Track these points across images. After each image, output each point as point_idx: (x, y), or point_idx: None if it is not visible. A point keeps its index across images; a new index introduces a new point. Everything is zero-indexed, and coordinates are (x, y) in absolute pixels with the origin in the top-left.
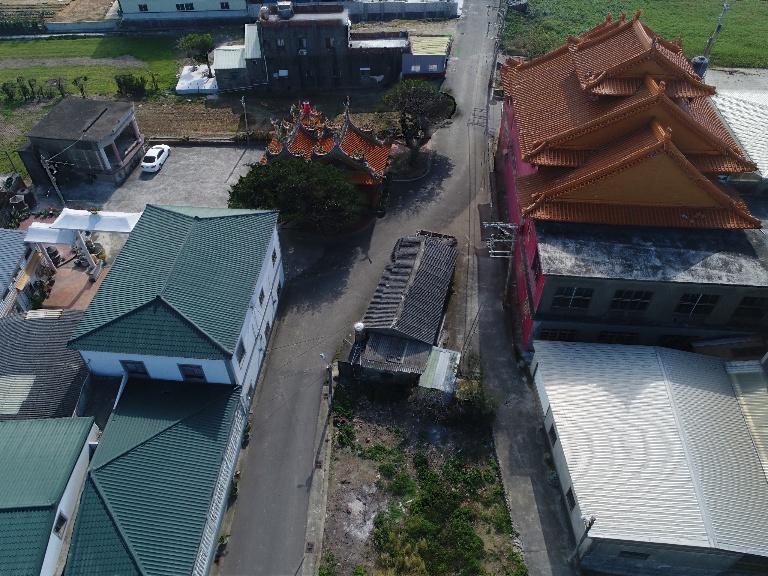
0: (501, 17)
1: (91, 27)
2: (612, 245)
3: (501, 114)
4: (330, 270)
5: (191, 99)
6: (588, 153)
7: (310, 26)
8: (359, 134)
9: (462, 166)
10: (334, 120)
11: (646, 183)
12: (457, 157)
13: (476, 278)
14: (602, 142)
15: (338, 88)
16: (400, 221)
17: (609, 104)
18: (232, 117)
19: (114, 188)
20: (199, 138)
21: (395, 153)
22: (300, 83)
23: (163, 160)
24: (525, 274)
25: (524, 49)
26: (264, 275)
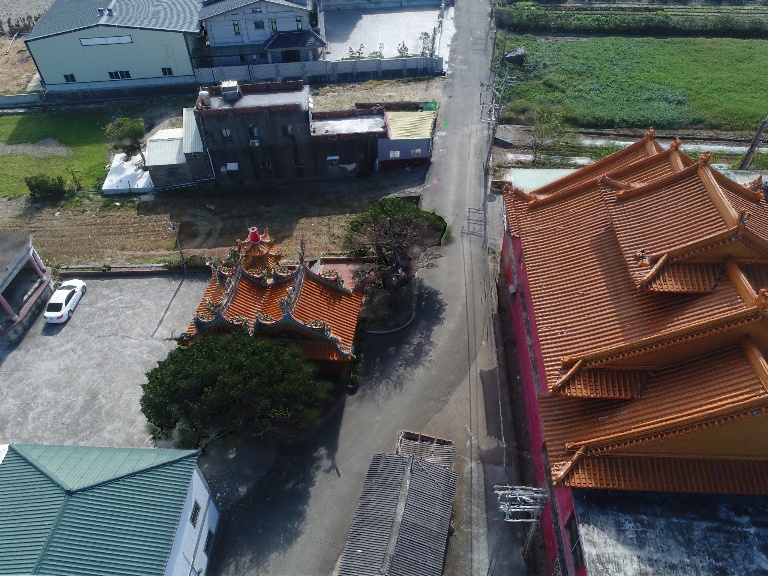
0: (496, 81)
1: (9, 102)
2: (690, 525)
3: (504, 232)
4: (283, 490)
5: (120, 202)
6: (645, 375)
7: (261, 113)
8: (320, 282)
9: (457, 305)
10: (296, 227)
11: (741, 437)
12: (450, 289)
13: (483, 504)
14: (666, 361)
15: (301, 179)
16: (378, 401)
17: (674, 302)
18: (169, 227)
19: (7, 350)
20: (123, 266)
21: (371, 285)
22: (254, 176)
23: (74, 304)
24: (555, 530)
25: (524, 116)
26: (175, 563)
